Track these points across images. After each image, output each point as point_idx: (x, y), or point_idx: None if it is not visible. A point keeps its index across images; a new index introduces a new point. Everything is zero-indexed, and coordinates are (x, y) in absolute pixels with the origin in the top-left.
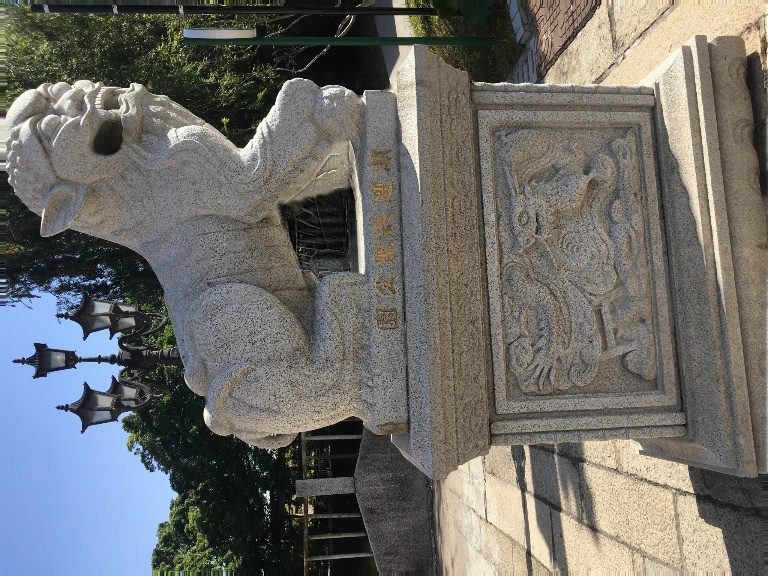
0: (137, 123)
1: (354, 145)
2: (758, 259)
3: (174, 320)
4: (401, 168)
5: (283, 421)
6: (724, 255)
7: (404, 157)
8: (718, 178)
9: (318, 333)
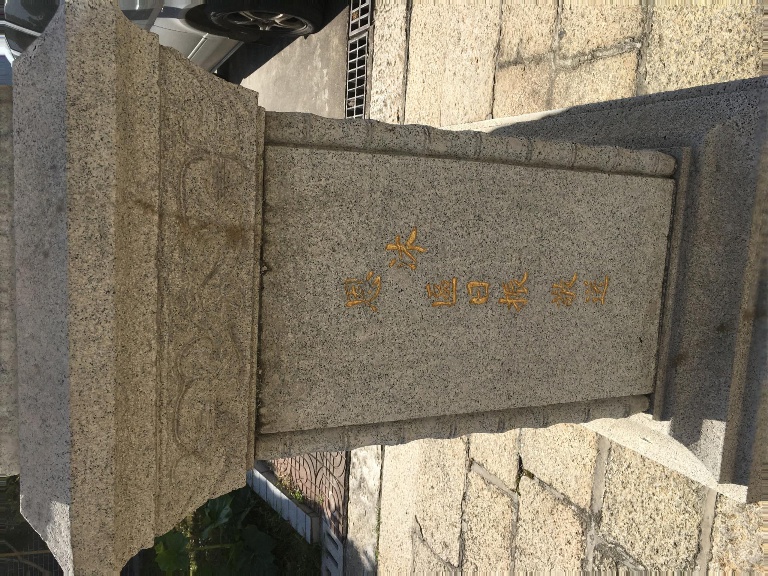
0: None
1: None
2: None
3: None
4: None
5: None
6: None
7: None
8: None
9: None
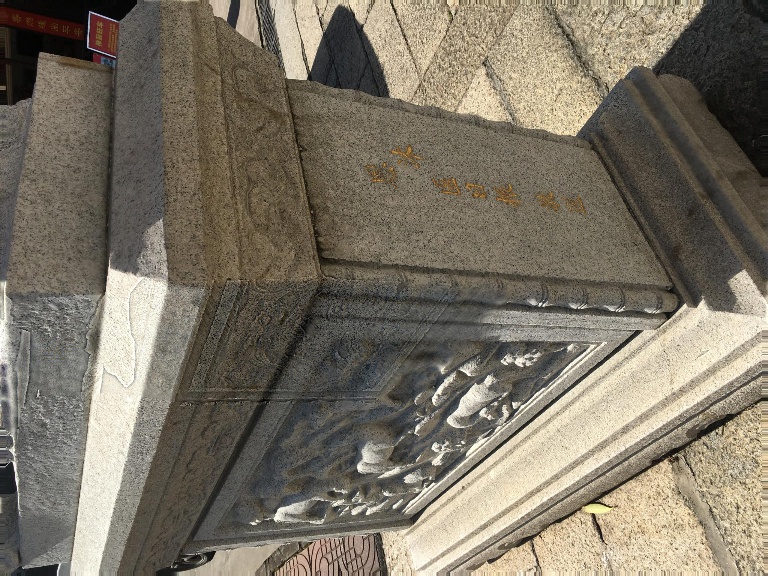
0: None
1: None
2: None
3: None
4: None
5: None
6: None
7: None
8: None
9: None
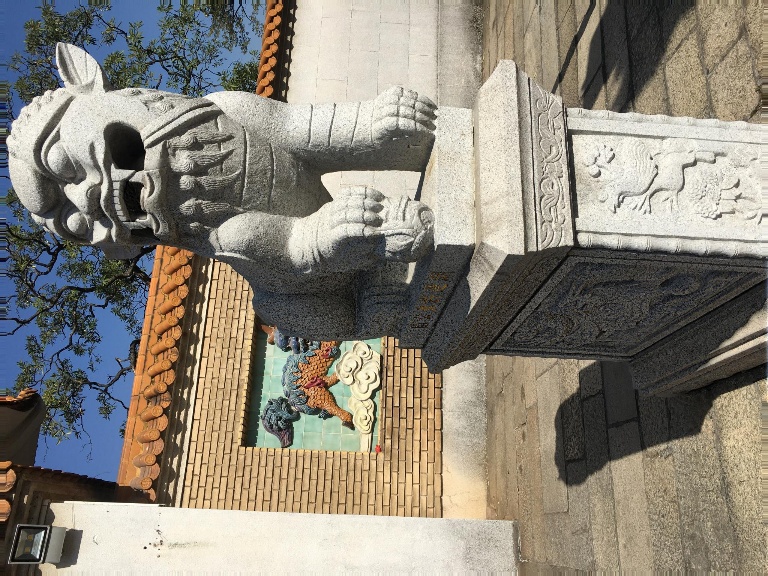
0: (173, 236)
1: None
2: None
3: None
4: (459, 286)
5: None
6: None
7: (464, 285)
8: None
9: (362, 318)
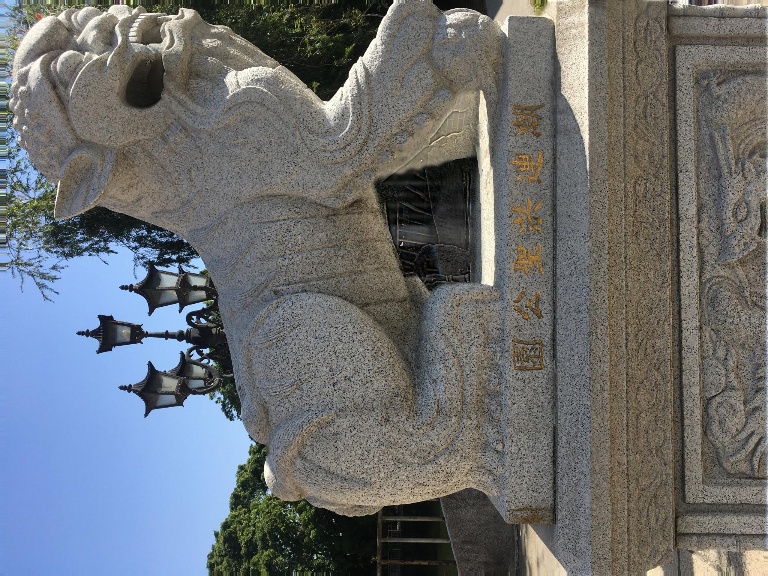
0: (184, 63)
1: (488, 97)
2: None
3: (230, 334)
4: (558, 132)
5: (373, 494)
6: None
7: (563, 115)
8: None
9: (426, 370)
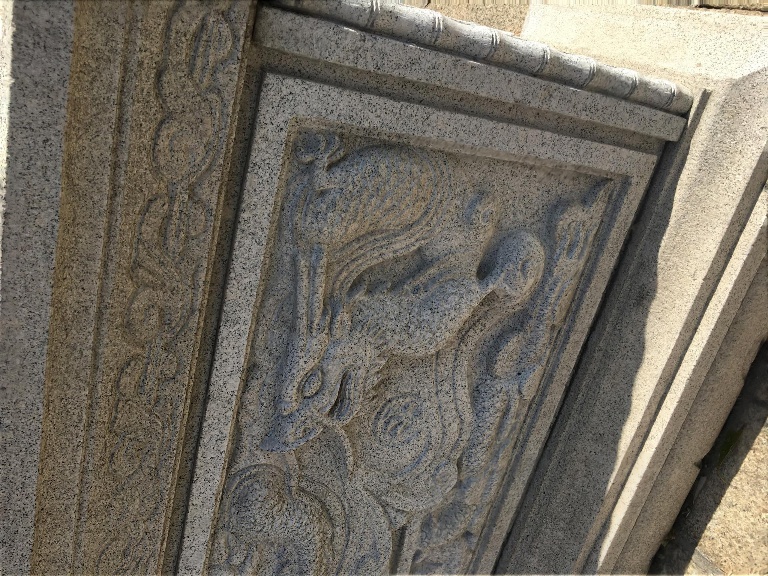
0: None
1: None
2: (684, 483)
3: None
4: None
5: None
6: (645, 484)
7: None
8: (710, 356)
9: None
